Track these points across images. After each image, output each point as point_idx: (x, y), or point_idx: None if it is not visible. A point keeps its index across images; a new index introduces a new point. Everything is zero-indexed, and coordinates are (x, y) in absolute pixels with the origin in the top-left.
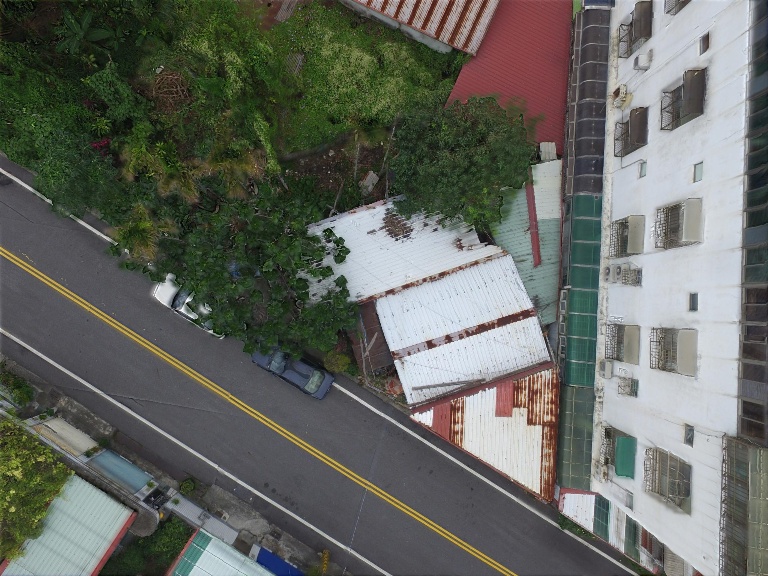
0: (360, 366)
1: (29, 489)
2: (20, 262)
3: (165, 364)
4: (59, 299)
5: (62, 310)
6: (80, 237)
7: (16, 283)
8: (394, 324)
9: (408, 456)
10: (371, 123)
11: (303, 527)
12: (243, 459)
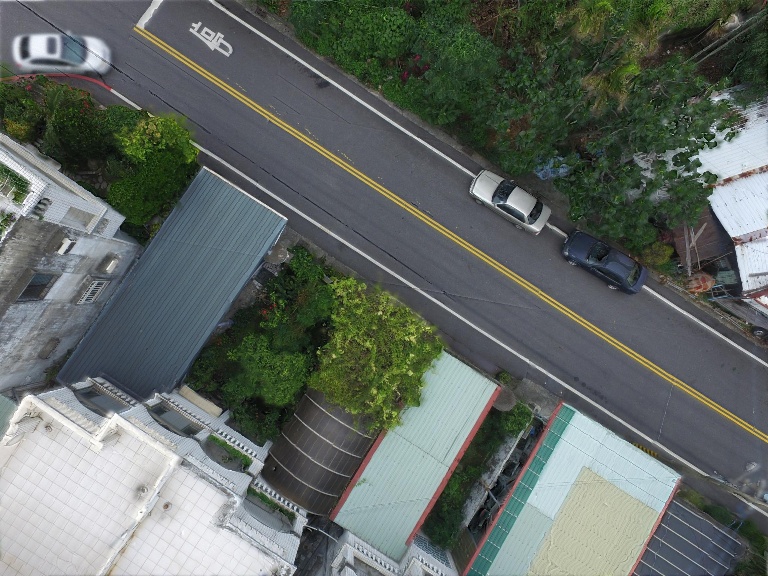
0: (683, 258)
1: (421, 355)
2: (339, 161)
3: (477, 261)
4: (376, 197)
5: (379, 208)
6: (394, 138)
7: (336, 181)
8: (729, 212)
9: (712, 353)
10: (687, 23)
11: (612, 421)
12: (554, 353)
